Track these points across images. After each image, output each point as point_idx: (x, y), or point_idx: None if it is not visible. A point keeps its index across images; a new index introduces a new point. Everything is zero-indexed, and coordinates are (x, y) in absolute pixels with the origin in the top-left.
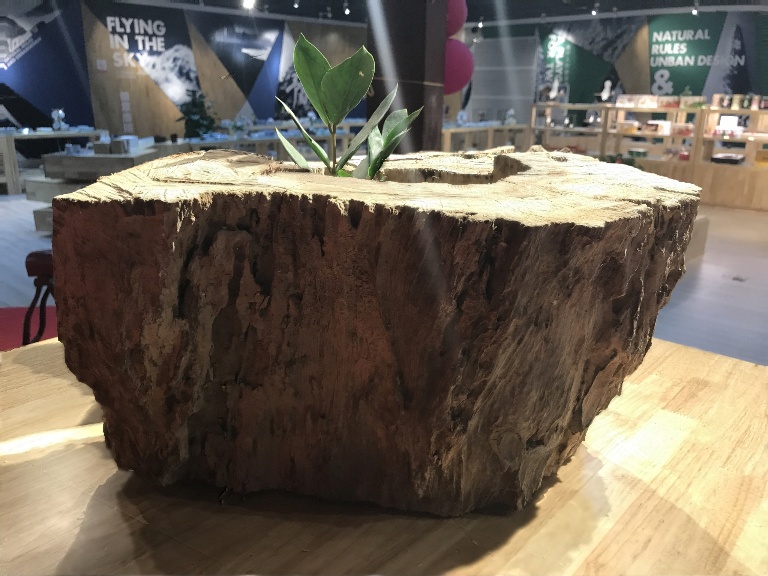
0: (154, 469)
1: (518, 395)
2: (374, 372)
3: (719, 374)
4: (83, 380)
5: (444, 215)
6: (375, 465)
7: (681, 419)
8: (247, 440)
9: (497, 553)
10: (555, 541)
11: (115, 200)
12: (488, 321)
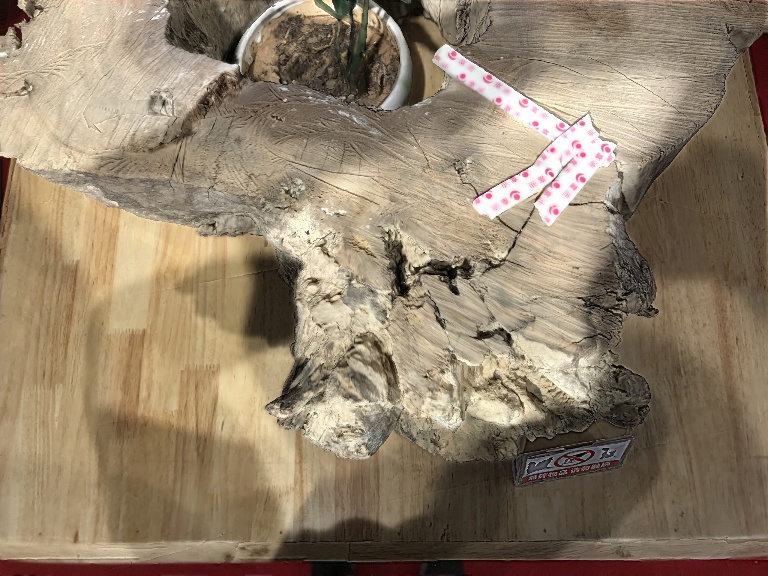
0: None
1: None
2: None
3: (110, 471)
4: None
5: None
6: None
7: (123, 320)
8: None
9: None
10: None
11: None
12: None
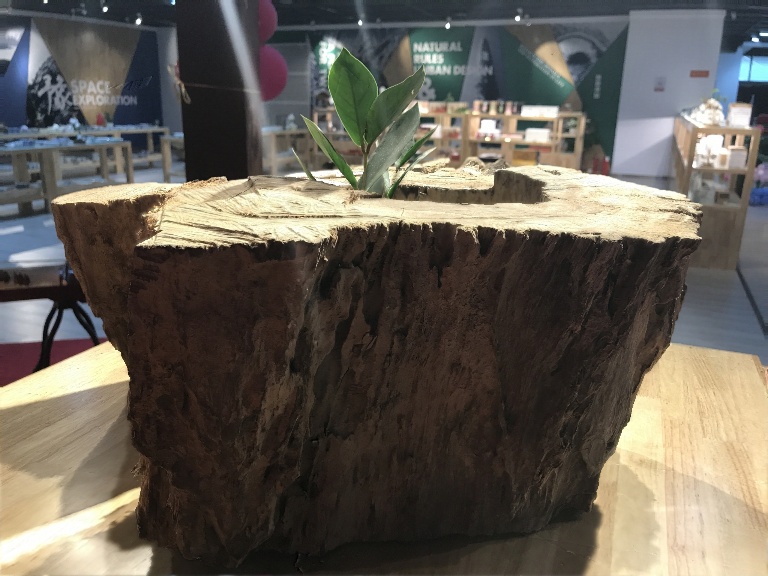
0: (236, 551)
1: (605, 402)
2: (471, 401)
3: None
4: (158, 463)
5: (577, 237)
6: (461, 495)
7: (647, 400)
8: (332, 496)
9: (596, 557)
10: (633, 534)
11: (240, 244)
12: (609, 336)
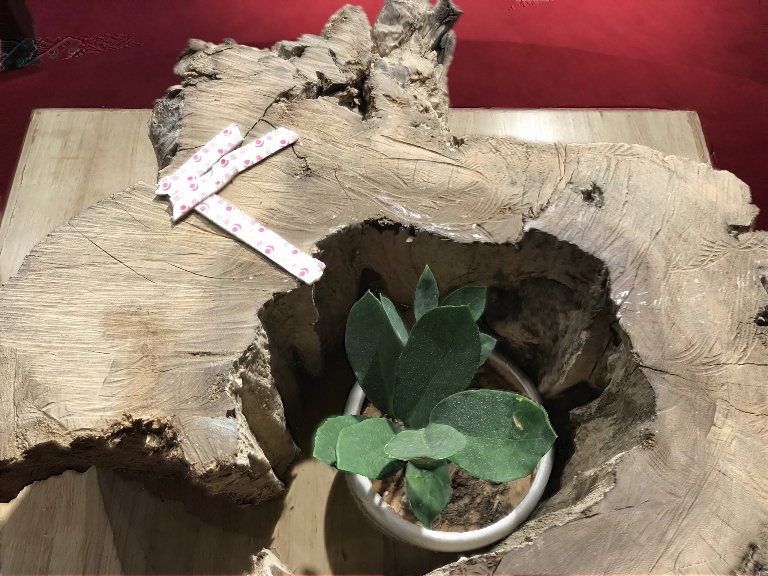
0: None
1: None
2: None
3: None
4: None
5: None
6: None
7: None
8: None
9: None
10: None
11: None
12: None
